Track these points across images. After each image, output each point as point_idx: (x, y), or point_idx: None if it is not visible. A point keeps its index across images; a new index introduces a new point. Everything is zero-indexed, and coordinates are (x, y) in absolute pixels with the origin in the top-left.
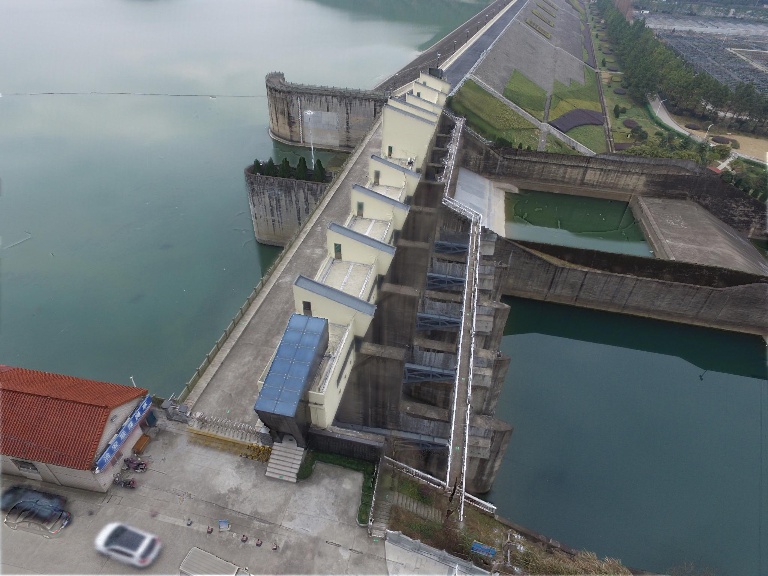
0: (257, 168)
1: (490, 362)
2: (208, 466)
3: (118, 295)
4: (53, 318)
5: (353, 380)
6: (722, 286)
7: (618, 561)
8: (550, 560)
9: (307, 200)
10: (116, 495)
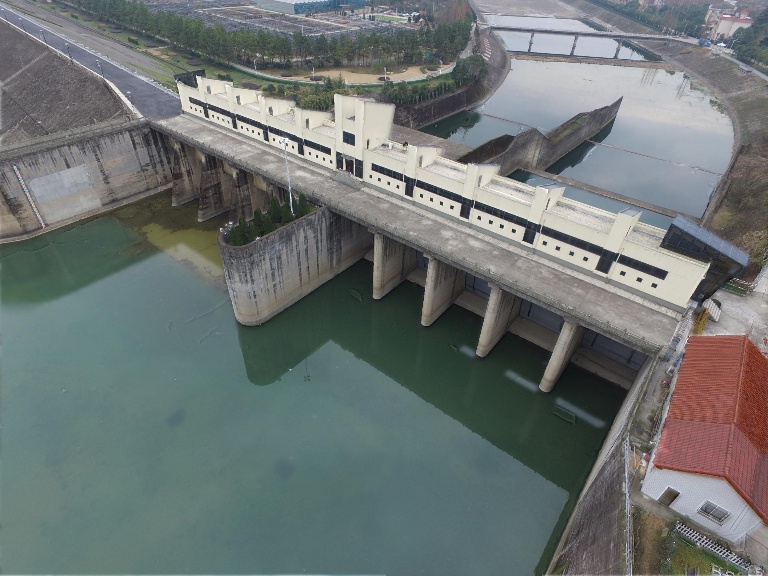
0: (238, 237)
1: None
2: None
3: (261, 489)
4: None
5: None
6: (497, 151)
7: (747, 234)
8: (760, 245)
9: (306, 238)
10: None
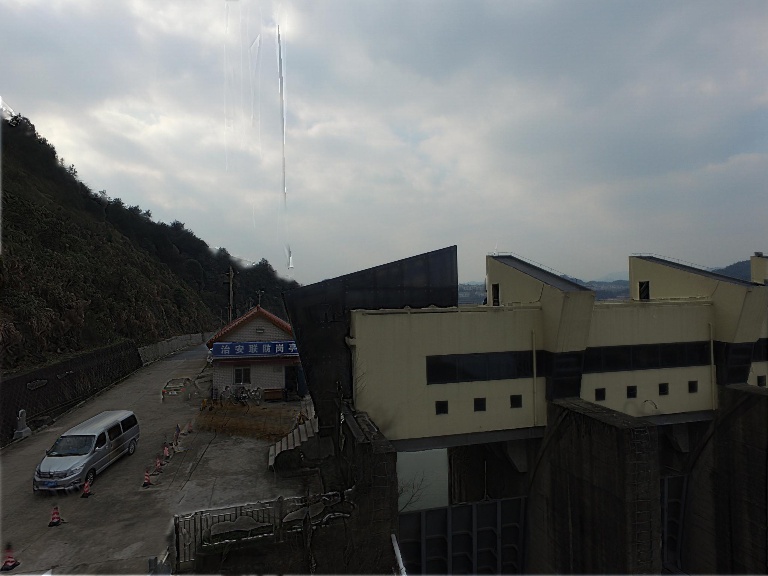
0: None
1: None
2: (267, 423)
3: None
4: None
5: (546, 489)
6: None
7: None
8: None
9: None
10: None
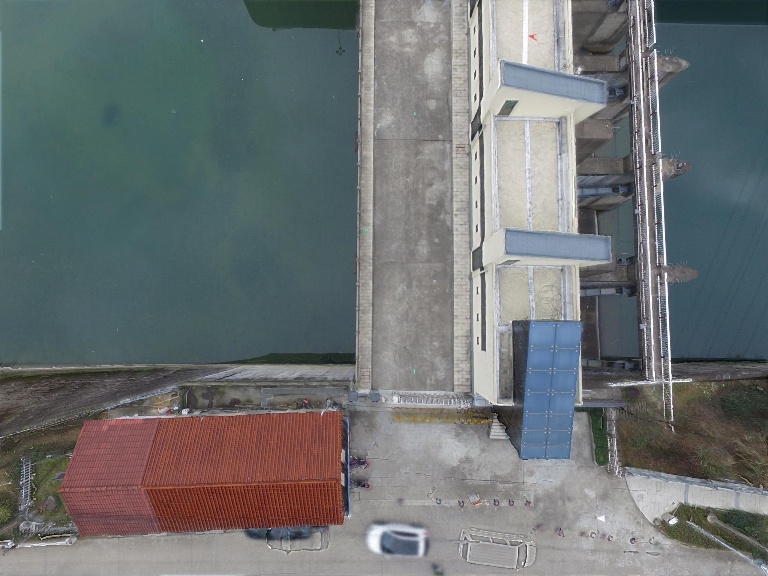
0: None
1: (666, 177)
2: (426, 441)
3: (79, 115)
4: (22, 180)
5: None
6: None
7: None
8: None
9: None
10: (352, 492)
